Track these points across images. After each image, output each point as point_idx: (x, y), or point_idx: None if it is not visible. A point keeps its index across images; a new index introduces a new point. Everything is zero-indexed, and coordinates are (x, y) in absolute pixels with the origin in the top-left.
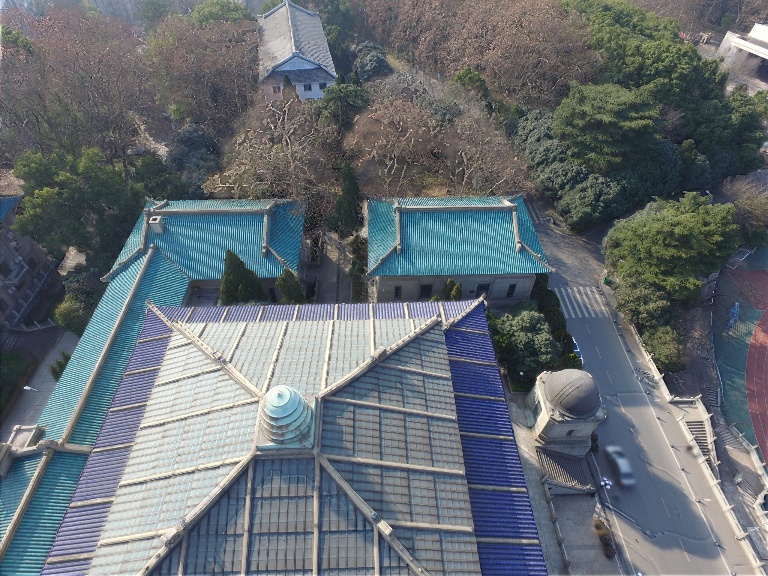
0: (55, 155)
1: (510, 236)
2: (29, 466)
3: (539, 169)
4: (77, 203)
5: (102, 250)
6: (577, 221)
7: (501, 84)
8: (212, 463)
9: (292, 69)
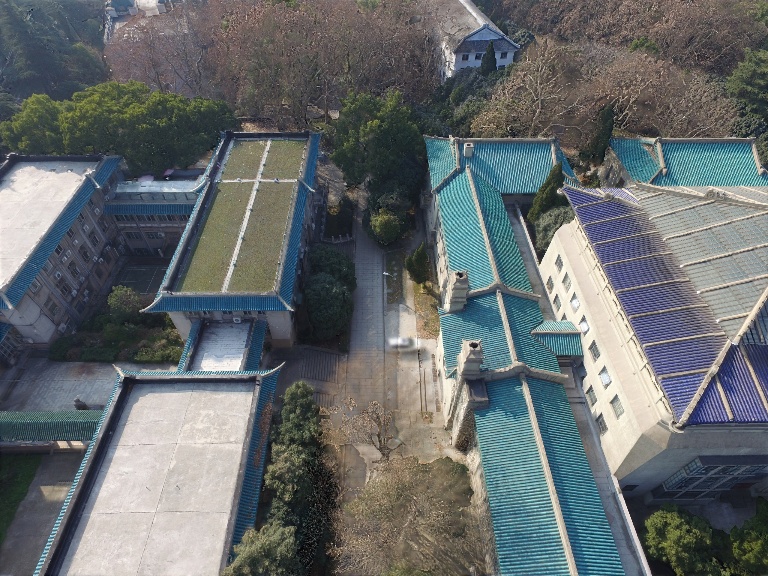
0: (370, 96)
1: (752, 163)
2: (482, 302)
3: (719, 123)
4: (383, 136)
5: (387, 179)
6: (765, 164)
7: (667, 53)
8: (767, 243)
9: (480, 39)
